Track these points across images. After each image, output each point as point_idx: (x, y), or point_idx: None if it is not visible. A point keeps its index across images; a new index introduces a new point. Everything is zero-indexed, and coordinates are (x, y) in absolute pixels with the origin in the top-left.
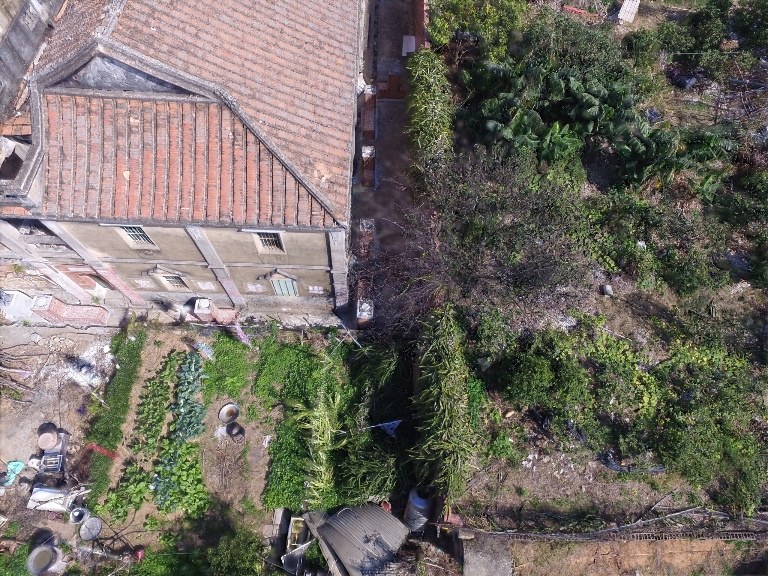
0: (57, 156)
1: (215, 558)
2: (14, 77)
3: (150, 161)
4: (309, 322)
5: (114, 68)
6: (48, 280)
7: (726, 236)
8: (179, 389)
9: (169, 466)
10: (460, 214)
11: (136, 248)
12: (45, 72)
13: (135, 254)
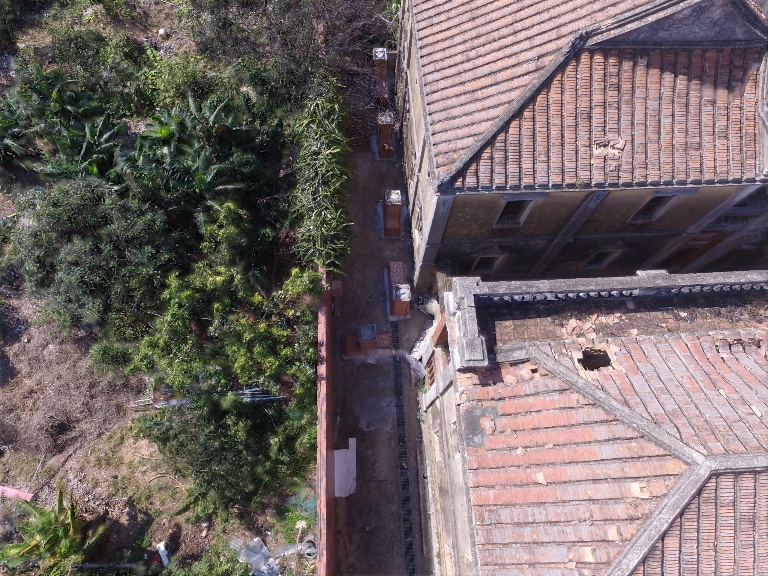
0: None
1: None
2: (761, 6)
3: None
4: None
5: None
6: None
7: (7, 88)
8: None
9: None
10: None
11: None
12: None
13: None
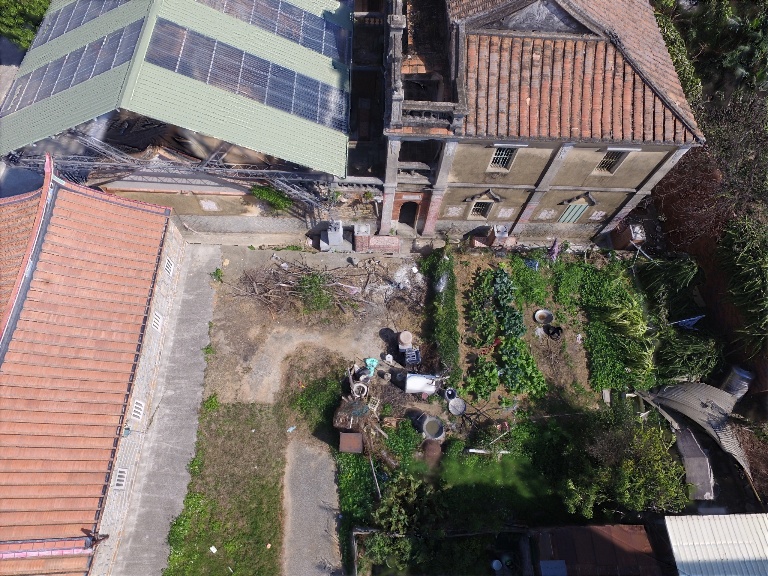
0: (474, 86)
1: (602, 414)
2: None
3: (547, 90)
4: (572, 249)
5: (543, 10)
6: (376, 208)
7: None
8: (500, 297)
9: (512, 356)
10: (726, 147)
11: (489, 171)
12: (478, 15)
13: (482, 178)
